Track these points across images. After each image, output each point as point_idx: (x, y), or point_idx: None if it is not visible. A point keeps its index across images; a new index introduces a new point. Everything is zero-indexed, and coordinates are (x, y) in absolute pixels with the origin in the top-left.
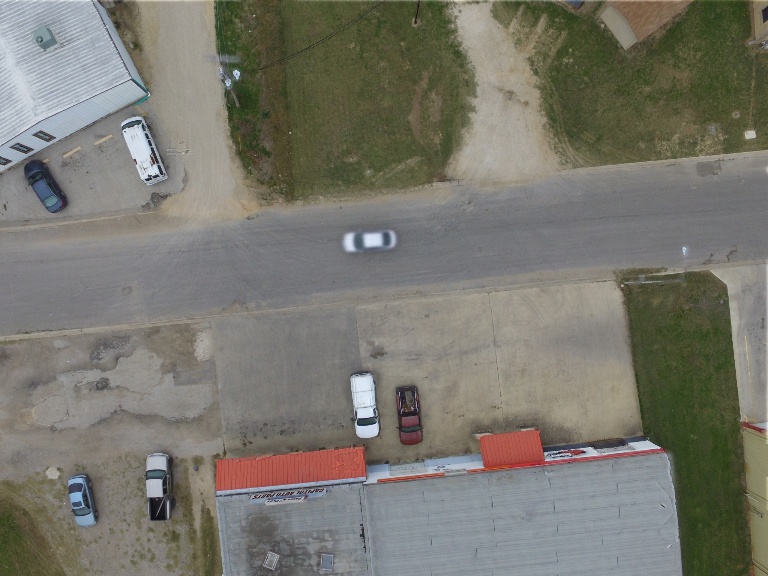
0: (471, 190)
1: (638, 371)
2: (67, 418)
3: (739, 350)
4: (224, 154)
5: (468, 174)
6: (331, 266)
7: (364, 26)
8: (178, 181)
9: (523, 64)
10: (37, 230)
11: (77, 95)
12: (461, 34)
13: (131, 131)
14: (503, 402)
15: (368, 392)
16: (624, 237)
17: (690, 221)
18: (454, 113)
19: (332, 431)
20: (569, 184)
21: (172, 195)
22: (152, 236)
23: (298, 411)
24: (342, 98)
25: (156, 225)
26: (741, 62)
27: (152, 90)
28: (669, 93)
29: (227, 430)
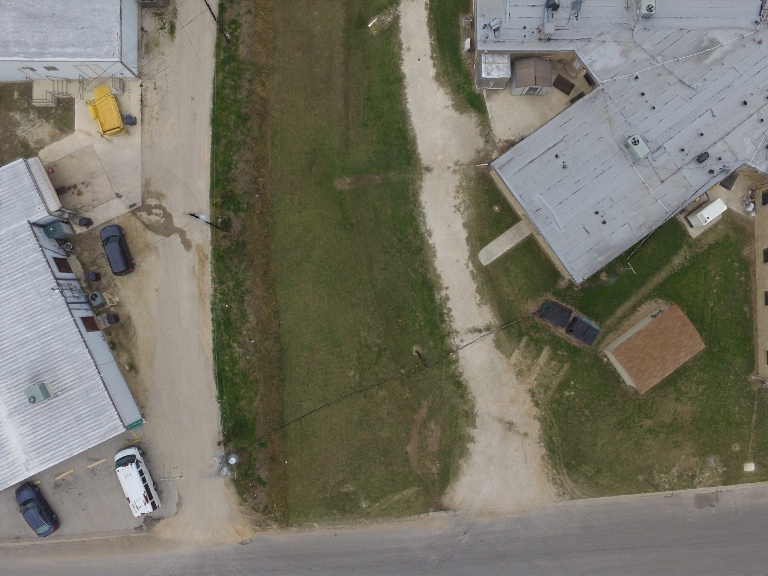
0: (467, 520)
1: None
2: None
3: None
4: (219, 480)
5: (464, 504)
6: None
7: (364, 354)
8: (172, 505)
9: (524, 395)
10: (28, 547)
11: (70, 449)
12: (462, 364)
13: (124, 471)
14: None
15: None
16: (618, 569)
17: (685, 553)
18: (452, 444)
19: None
20: (565, 515)
21: (165, 518)
22: (144, 558)
23: None
24: (340, 427)
25: (148, 547)
26: (743, 396)
27: (147, 415)
28: (669, 426)
29: None
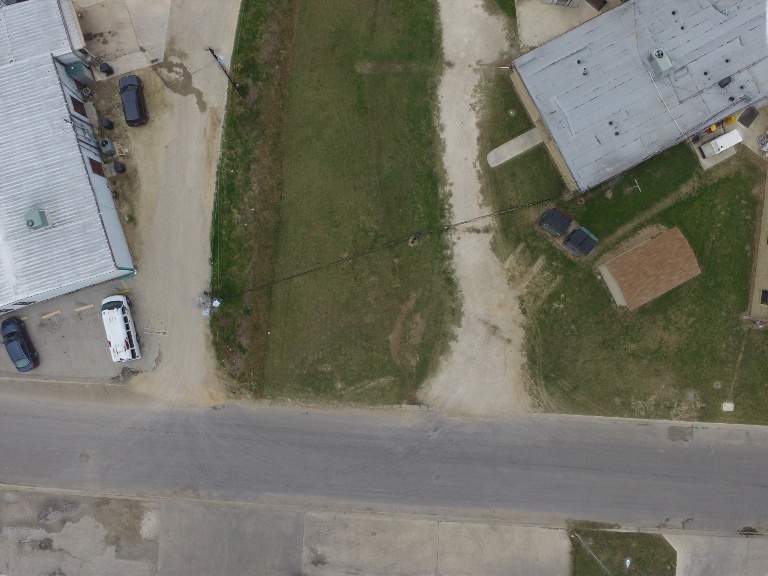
0: (439, 418)
1: None
2: (6, 572)
3: None
4: (200, 342)
5: (439, 401)
6: (288, 469)
7: (360, 237)
8: (151, 360)
9: (513, 301)
10: (6, 382)
11: (60, 279)
12: (456, 261)
13: (110, 314)
14: None
15: None
16: (583, 489)
17: (652, 483)
18: (435, 339)
19: None
20: (538, 428)
21: (143, 372)
22: (117, 408)
23: None
24: (326, 306)
25: (123, 398)
26: (732, 334)
27: (139, 267)
28: (654, 354)
29: None
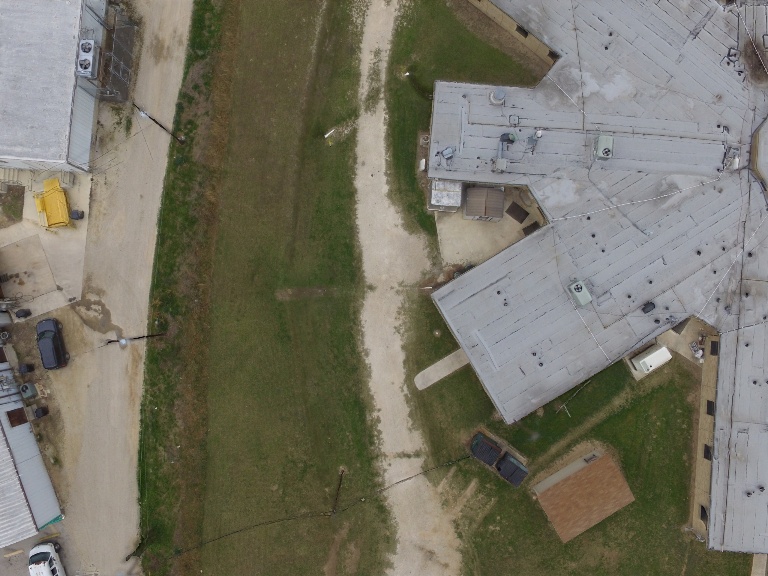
0: None
1: None
2: None
3: None
4: None
5: None
6: None
7: (290, 469)
8: None
9: (448, 526)
10: None
11: None
12: (388, 489)
13: (37, 569)
14: None
15: None
16: None
17: None
18: (371, 568)
19: None
20: None
21: None
22: None
23: None
24: (258, 541)
25: None
26: (674, 547)
27: (67, 510)
28: (595, 571)
29: None
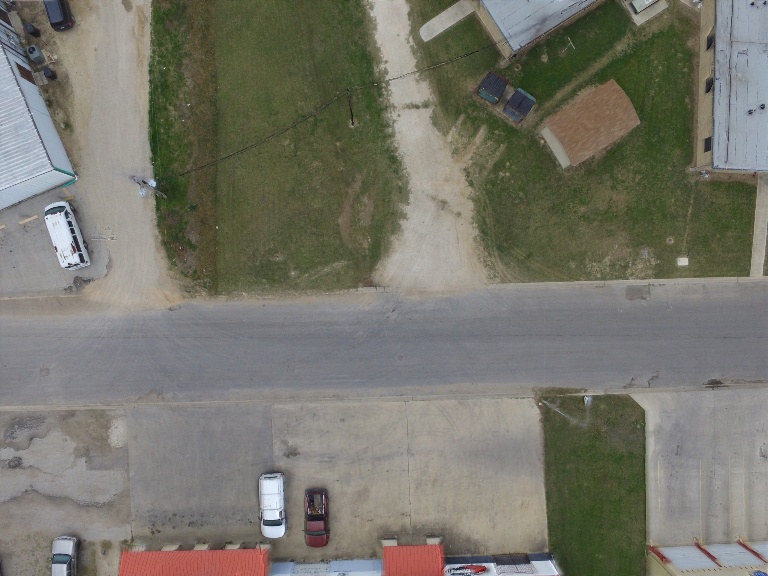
0: (396, 298)
1: (549, 489)
2: None
3: (651, 475)
4: (150, 243)
5: (394, 281)
6: (250, 364)
7: (300, 123)
8: (102, 267)
9: (459, 174)
10: None
11: None
12: (398, 139)
13: (53, 218)
14: (412, 510)
15: (275, 495)
16: (546, 356)
17: (614, 344)
18: (385, 219)
19: (240, 526)
20: (495, 299)
21: (95, 280)
22: (73, 319)
23: (207, 504)
24: (272, 196)
25: (77, 309)
26: (680, 188)
27: (80, 173)
28: (604, 214)
29: (136, 517)
